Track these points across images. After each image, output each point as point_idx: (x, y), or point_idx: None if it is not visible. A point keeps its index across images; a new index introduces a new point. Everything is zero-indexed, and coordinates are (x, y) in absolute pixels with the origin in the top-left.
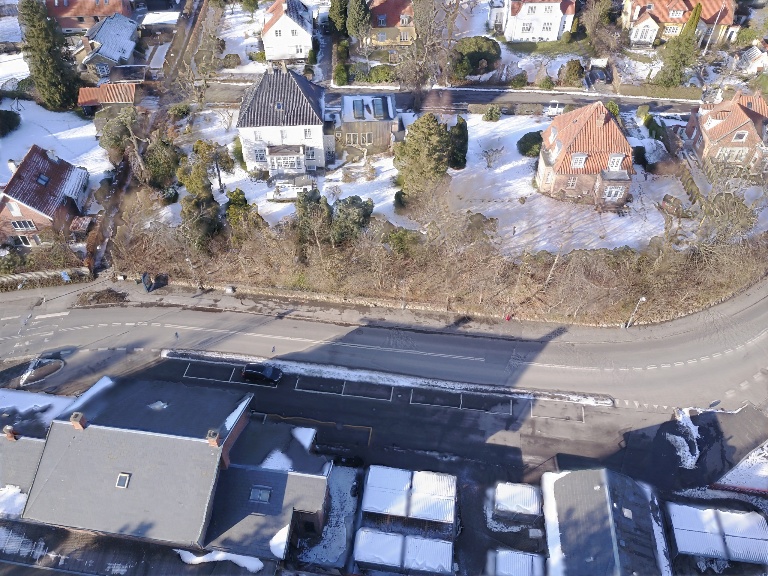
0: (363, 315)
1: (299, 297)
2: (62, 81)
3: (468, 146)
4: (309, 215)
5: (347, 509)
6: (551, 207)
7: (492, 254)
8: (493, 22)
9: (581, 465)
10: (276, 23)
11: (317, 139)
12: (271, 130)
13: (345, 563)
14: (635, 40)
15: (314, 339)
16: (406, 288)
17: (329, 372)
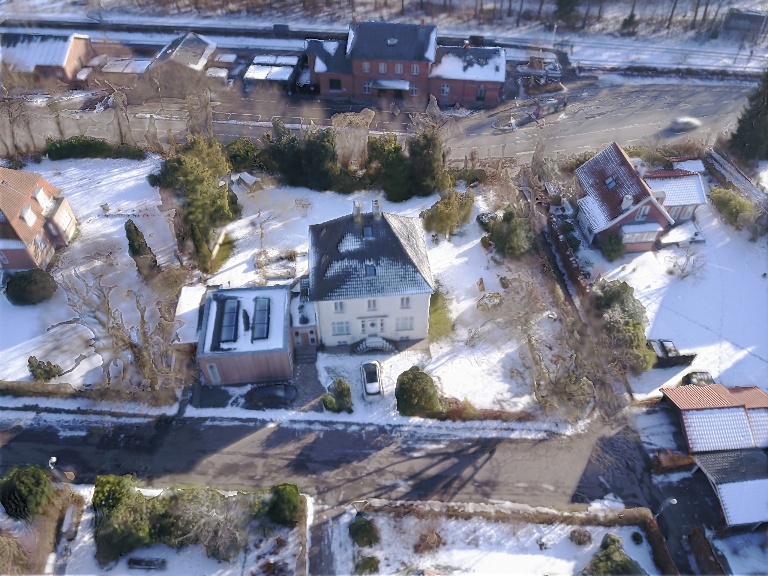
0: None
1: None
2: None
3: None
4: None
5: (302, 83)
6: (81, 202)
7: None
8: None
9: (174, 95)
10: None
11: None
12: None
13: (302, 55)
14: None
15: None
16: None
17: None
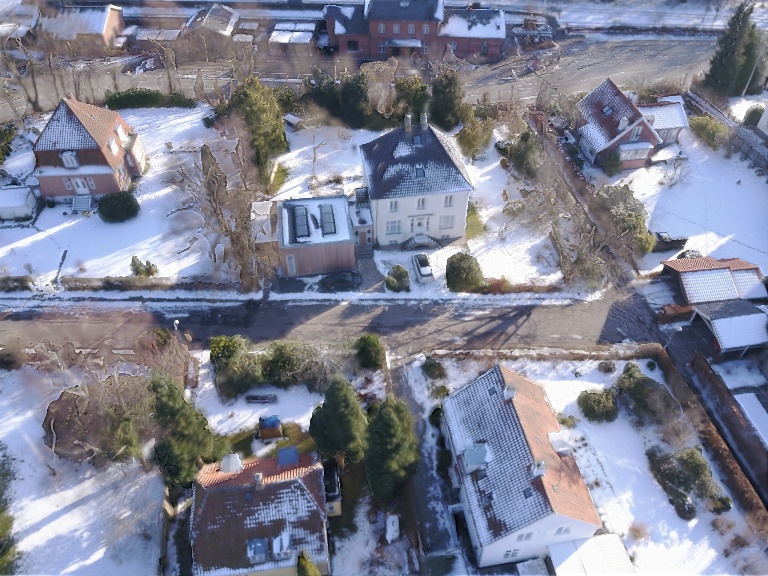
0: None
1: None
2: None
3: None
4: None
5: (321, 47)
6: (146, 142)
7: None
8: None
9: (205, 59)
10: None
11: None
12: None
13: (318, 21)
14: None
15: None
16: None
17: None
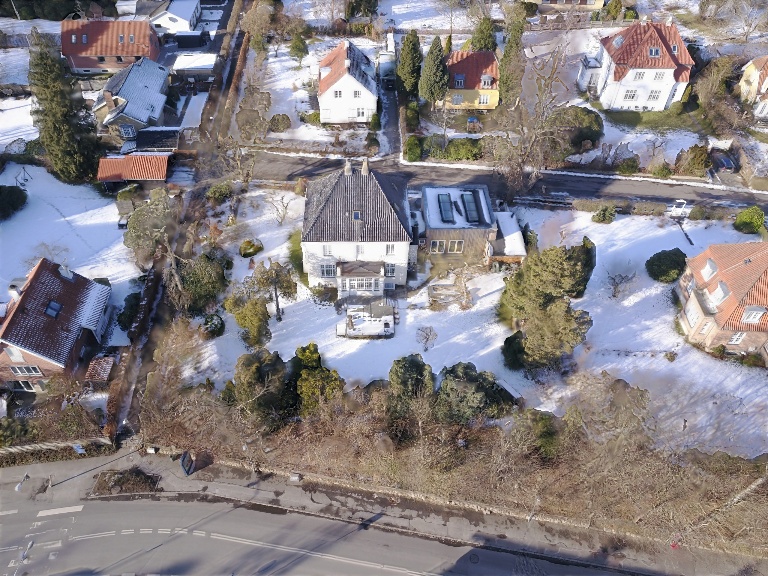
0: (476, 528)
1: (388, 493)
2: (79, 150)
3: (592, 272)
4: (410, 394)
5: None
6: (710, 369)
7: (647, 448)
8: (586, 84)
9: None
10: (337, 83)
11: (401, 255)
12: (345, 245)
13: None
14: (760, 116)
15: (414, 569)
16: (532, 490)
17: None
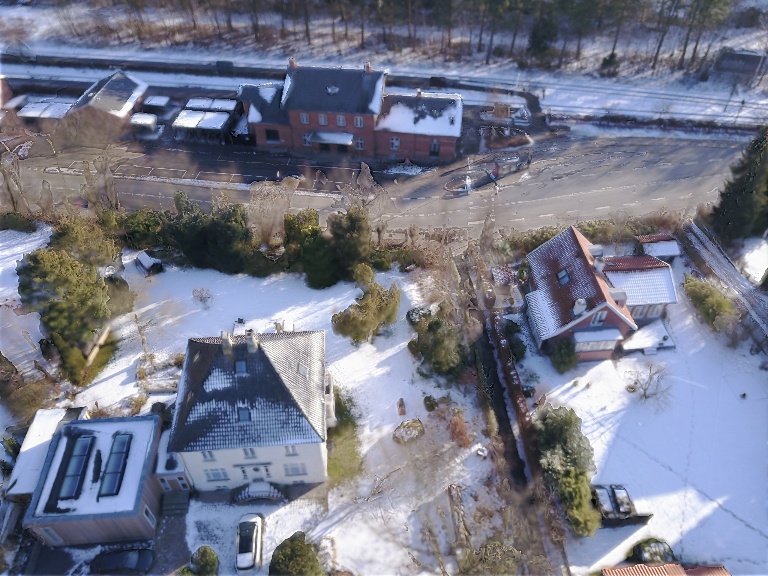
0: None
1: None
2: None
3: None
4: None
5: (239, 131)
6: None
7: None
8: None
9: (94, 144)
10: None
11: None
12: None
13: None
14: None
15: None
16: None
17: (241, 186)
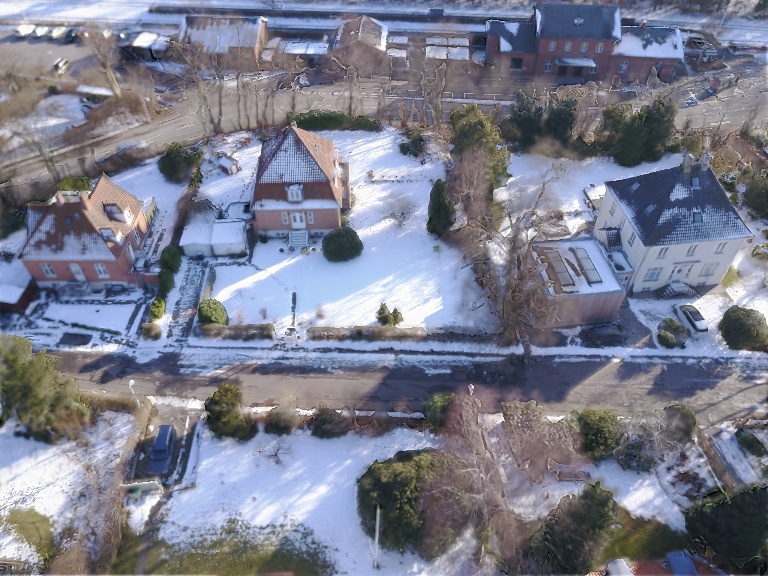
0: None
1: None
2: None
3: None
4: None
5: None
6: None
7: None
8: None
9: (359, 75)
10: None
11: None
12: None
13: (471, 36)
14: None
15: None
16: None
17: (506, 102)
